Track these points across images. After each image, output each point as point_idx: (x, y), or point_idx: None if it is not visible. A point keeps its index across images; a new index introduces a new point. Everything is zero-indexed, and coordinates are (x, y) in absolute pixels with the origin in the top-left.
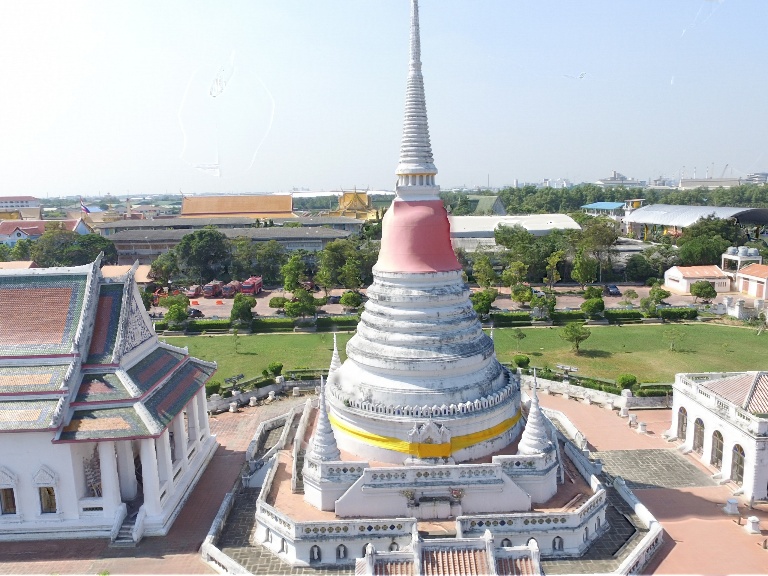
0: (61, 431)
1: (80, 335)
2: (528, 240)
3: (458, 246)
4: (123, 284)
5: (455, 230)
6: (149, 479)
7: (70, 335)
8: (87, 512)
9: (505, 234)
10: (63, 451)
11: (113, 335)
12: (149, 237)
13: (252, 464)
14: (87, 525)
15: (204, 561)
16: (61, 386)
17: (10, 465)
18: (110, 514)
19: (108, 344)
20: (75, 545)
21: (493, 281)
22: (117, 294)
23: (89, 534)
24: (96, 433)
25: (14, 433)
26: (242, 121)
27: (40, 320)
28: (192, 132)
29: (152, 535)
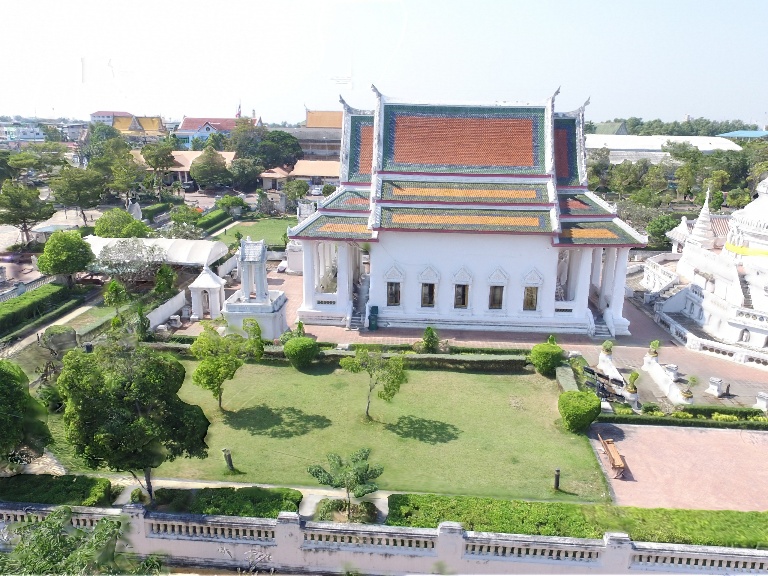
0: (558, 237)
1: (551, 159)
2: (700, 157)
3: (634, 159)
4: (575, 119)
5: (614, 147)
6: (620, 286)
7: (540, 160)
8: (559, 312)
9: (676, 150)
10: (552, 256)
11: (574, 162)
12: (327, 137)
13: (648, 296)
14: (563, 322)
15: (695, 351)
16: (551, 199)
17: (503, 266)
18: (581, 315)
19: (571, 170)
20: (559, 336)
21: (692, 189)
22: (570, 127)
23: (564, 330)
24: (590, 240)
25: (521, 235)
26: (376, 33)
27: (509, 146)
28: (329, 43)
29: (620, 334)
